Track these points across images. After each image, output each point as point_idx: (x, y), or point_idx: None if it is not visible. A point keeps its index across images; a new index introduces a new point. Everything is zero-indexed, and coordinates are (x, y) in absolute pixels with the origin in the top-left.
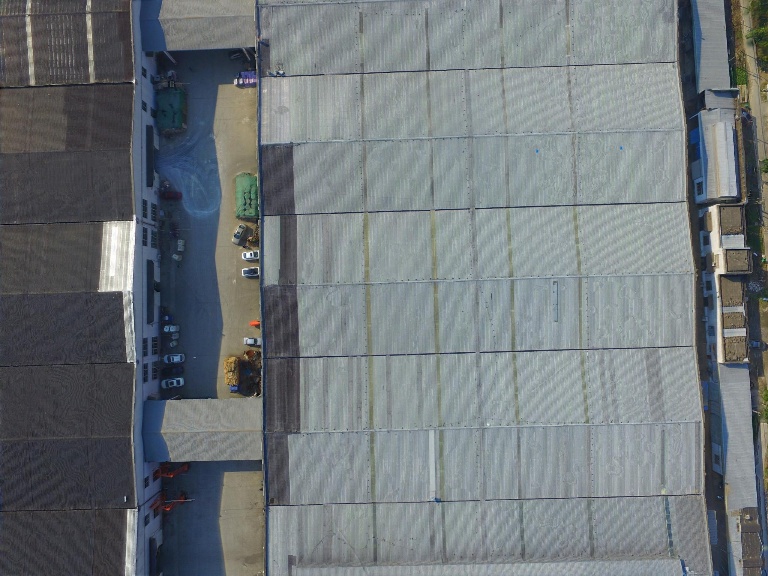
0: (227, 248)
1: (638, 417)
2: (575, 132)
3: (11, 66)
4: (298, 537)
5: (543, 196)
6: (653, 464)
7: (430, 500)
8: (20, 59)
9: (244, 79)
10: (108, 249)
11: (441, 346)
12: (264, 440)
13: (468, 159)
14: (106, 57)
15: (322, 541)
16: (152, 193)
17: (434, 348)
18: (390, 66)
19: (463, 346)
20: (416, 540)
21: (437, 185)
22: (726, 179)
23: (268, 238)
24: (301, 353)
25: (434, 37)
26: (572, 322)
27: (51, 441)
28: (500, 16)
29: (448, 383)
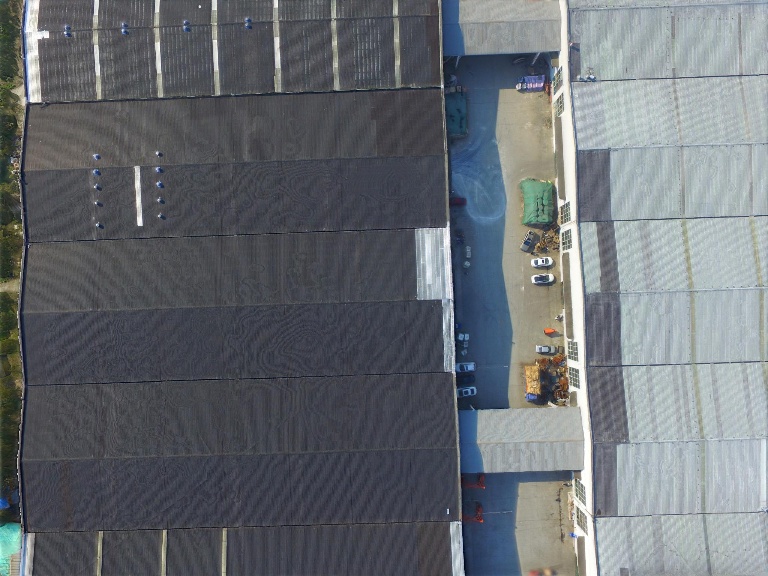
0: (514, 255)
1: None
2: None
3: (315, 71)
4: (629, 549)
5: None
6: None
7: (760, 510)
8: (324, 64)
9: (527, 84)
10: (423, 256)
11: (766, 354)
12: (593, 450)
13: None
14: (413, 62)
15: (653, 553)
16: None
17: (759, 356)
18: (702, 71)
19: None
20: (750, 551)
21: (756, 191)
22: None
23: (586, 245)
24: (623, 361)
25: (747, 42)
26: None
27: (373, 453)
28: None
29: None
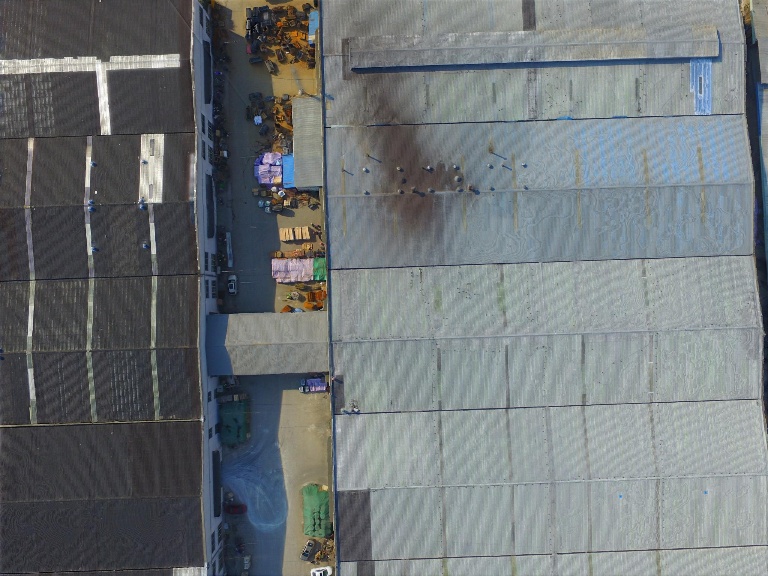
0: (295, 563)
1: None
2: (659, 477)
3: (71, 402)
4: None
5: (626, 541)
6: None
7: None
8: (81, 395)
9: (310, 386)
10: None
11: None
12: None
13: (550, 505)
14: (172, 394)
15: None
16: None
17: None
18: (469, 403)
19: None
20: None
21: (518, 530)
22: None
23: None
24: None
25: (514, 374)
26: None
27: None
28: (582, 353)
29: None
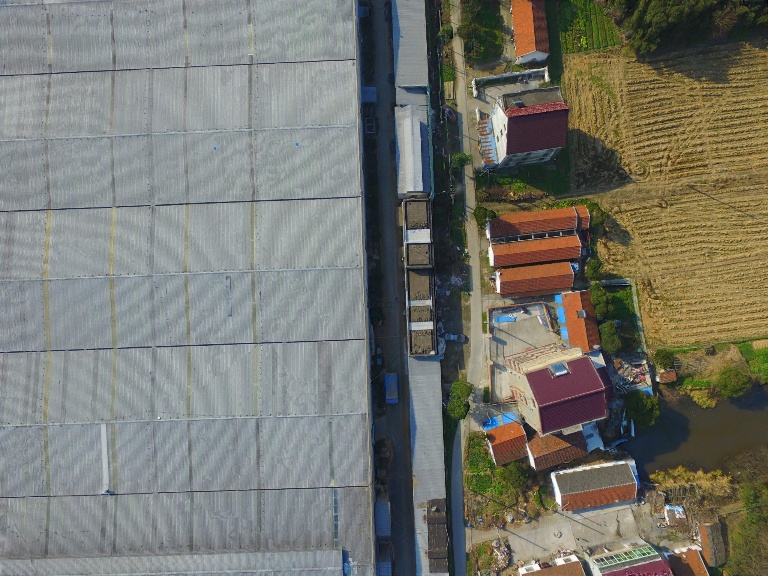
0: None
1: (306, 410)
2: (251, 129)
3: None
4: None
5: (221, 192)
6: (322, 456)
7: (104, 493)
8: None
9: None
10: None
11: (118, 341)
12: None
13: (148, 157)
14: None
15: None
16: None
17: (111, 343)
18: (77, 66)
19: (140, 341)
20: (87, 533)
21: (118, 182)
22: (411, 174)
23: None
24: None
25: (119, 37)
26: (246, 316)
27: None
28: (183, 16)
29: (123, 377)
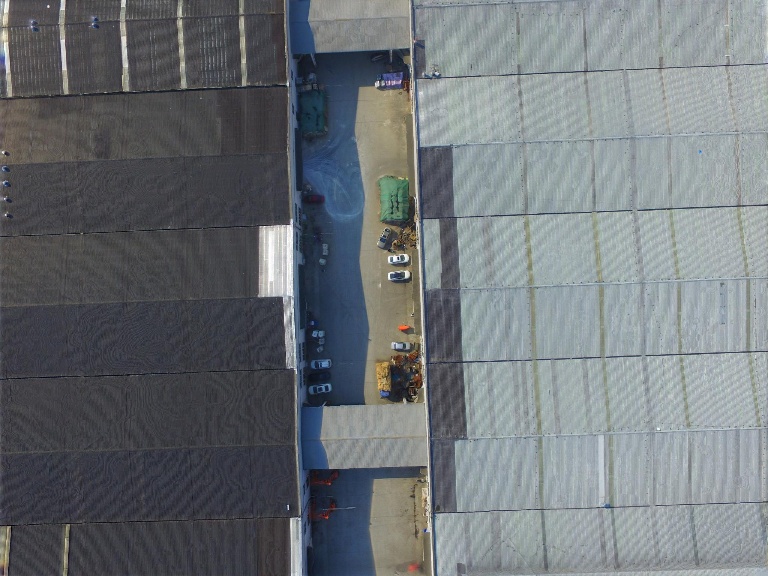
0: (371, 252)
1: None
2: (739, 132)
3: (162, 69)
4: (466, 545)
5: (706, 197)
6: None
7: (599, 506)
8: (171, 62)
9: (386, 81)
10: (266, 254)
11: (607, 350)
12: (431, 446)
13: (630, 160)
14: (259, 60)
15: (491, 549)
16: (298, 197)
17: (599, 352)
18: (547, 67)
19: (629, 349)
20: (587, 547)
21: (599, 187)
22: None
23: (428, 241)
24: (464, 358)
25: (592, 37)
26: (739, 324)
27: (213, 449)
28: (658, 16)
29: (615, 387)
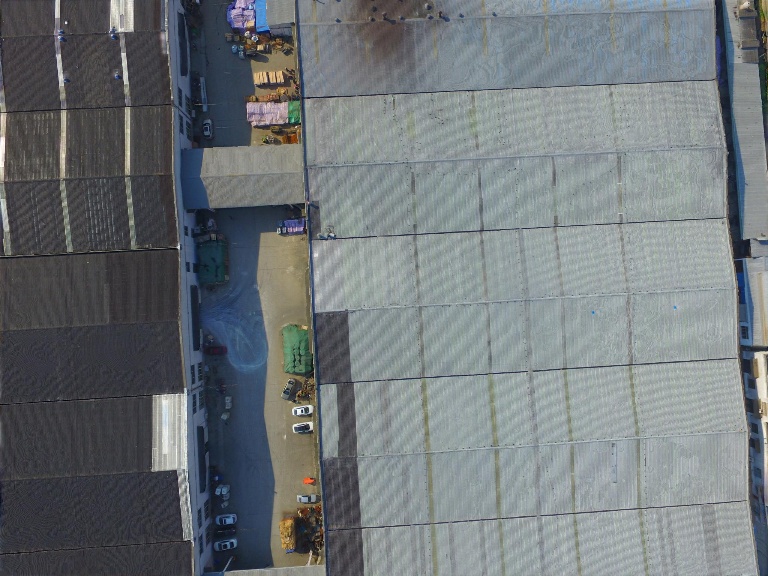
0: (276, 403)
1: (696, 575)
2: (630, 293)
3: (46, 233)
4: None
5: (599, 357)
6: None
7: None
8: (55, 225)
9: (287, 228)
10: (159, 425)
11: (503, 511)
12: None
13: (525, 322)
14: (148, 222)
15: None
16: (198, 353)
17: (496, 513)
18: (443, 227)
19: (524, 510)
20: None
21: (494, 349)
22: None
23: (325, 408)
24: (363, 524)
25: (487, 197)
26: (630, 482)
27: None
28: (553, 174)
29: (511, 549)
